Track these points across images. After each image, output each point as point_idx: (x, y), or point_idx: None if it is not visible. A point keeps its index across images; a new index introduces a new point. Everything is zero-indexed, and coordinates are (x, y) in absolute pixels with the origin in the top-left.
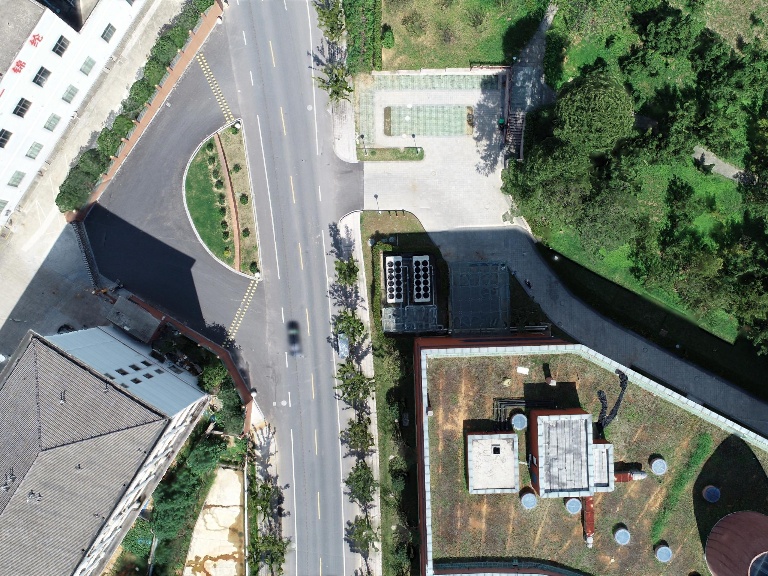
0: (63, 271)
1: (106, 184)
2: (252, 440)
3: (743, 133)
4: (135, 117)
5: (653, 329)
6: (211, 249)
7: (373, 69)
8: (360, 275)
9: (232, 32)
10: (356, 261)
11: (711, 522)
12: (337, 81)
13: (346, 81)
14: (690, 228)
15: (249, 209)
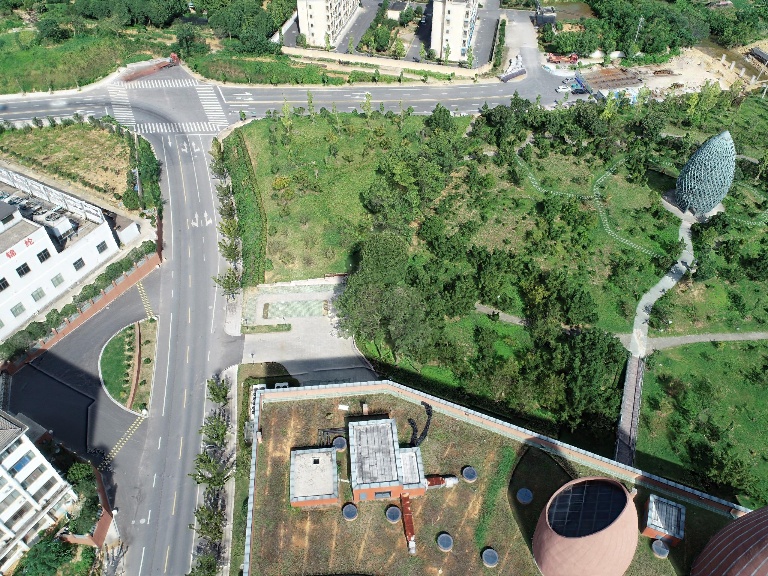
0: None
1: (41, 352)
2: (100, 560)
3: (517, 297)
4: (80, 308)
5: None
6: (110, 392)
7: (258, 284)
8: (233, 408)
9: (165, 272)
10: (231, 399)
11: (532, 525)
12: None
13: (239, 292)
14: (497, 357)
15: (150, 368)
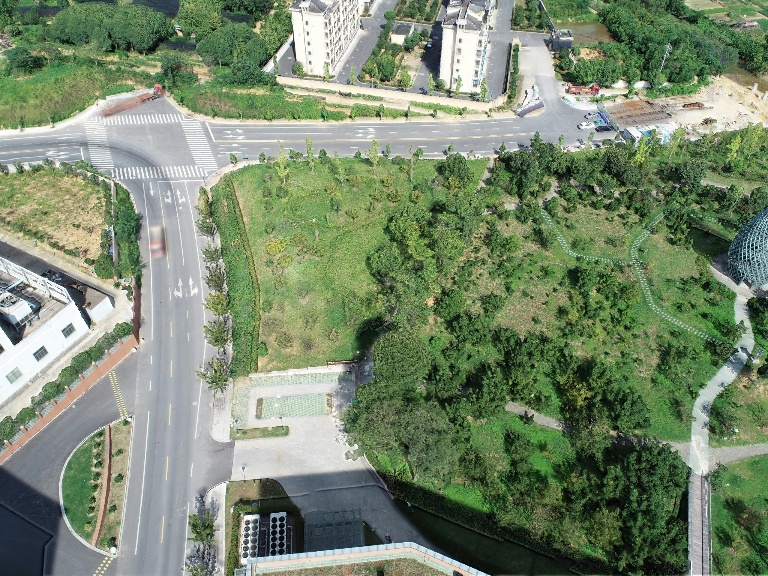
0: None
1: None
2: None
3: (553, 393)
4: (39, 411)
5: None
6: (73, 524)
7: (250, 373)
8: (219, 544)
9: (142, 357)
10: (217, 530)
11: None
12: None
13: (228, 383)
14: (532, 473)
15: (122, 487)
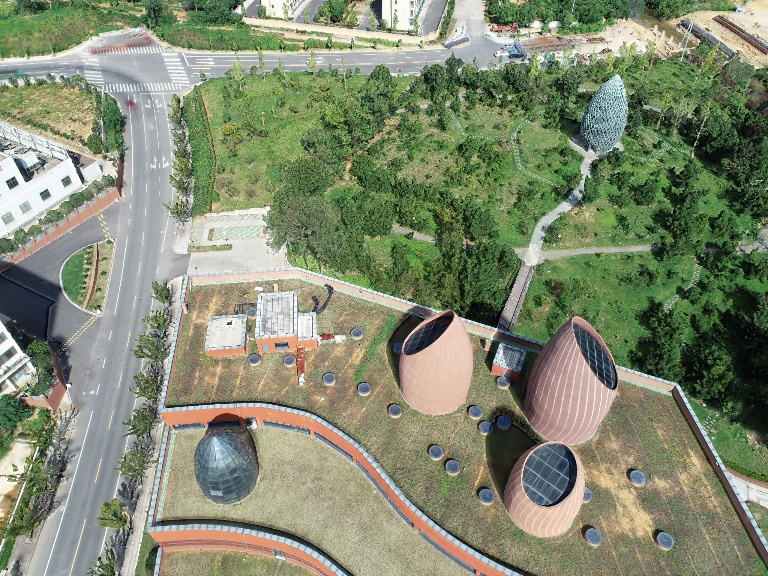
0: None
1: (10, 265)
2: (55, 420)
3: (432, 221)
4: (45, 229)
5: None
6: (69, 296)
7: (206, 213)
8: (176, 309)
9: (124, 205)
10: (175, 302)
11: None
12: (177, 206)
13: (188, 220)
14: None
15: (106, 279)
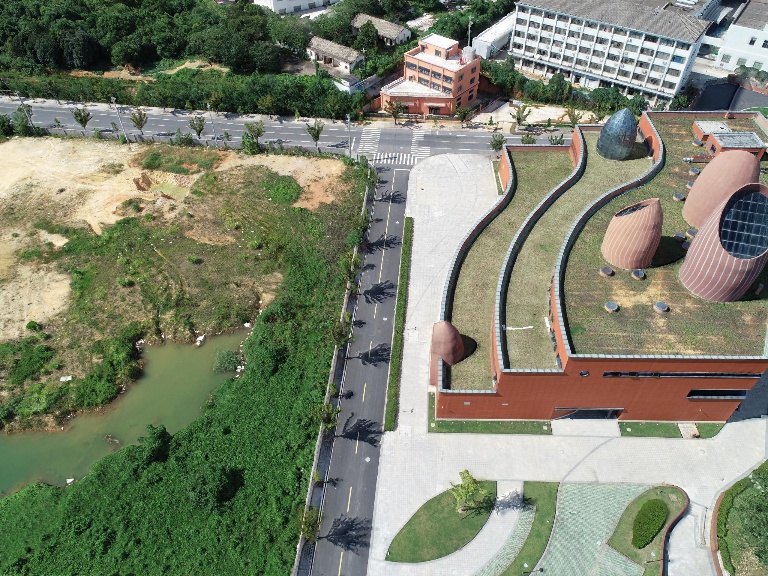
0: (702, 78)
1: (750, 89)
2: None
3: None
4: None
5: None
6: None
7: None
8: None
9: None
10: None
11: None
12: None
13: None
14: None
15: None
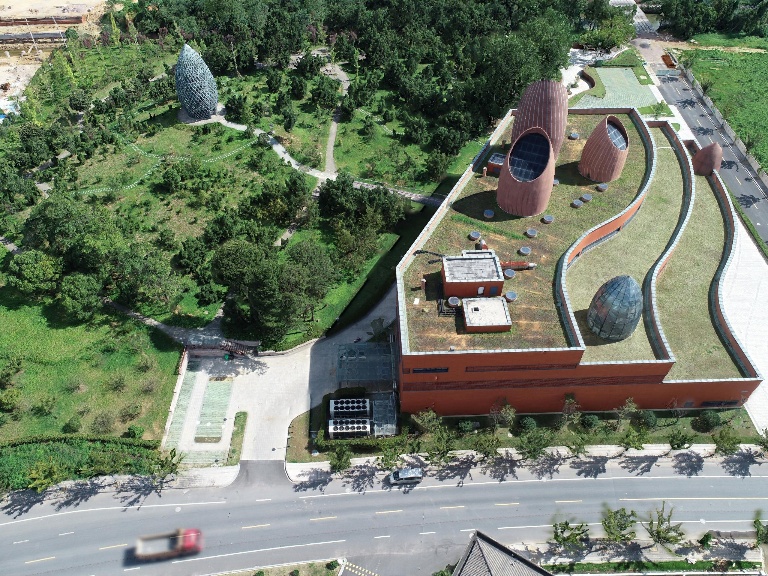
0: None
1: None
2: None
3: None
4: None
5: (391, 273)
6: None
7: None
8: None
9: None
10: None
11: (507, 215)
12: (163, 463)
13: None
14: None
15: (270, 572)
